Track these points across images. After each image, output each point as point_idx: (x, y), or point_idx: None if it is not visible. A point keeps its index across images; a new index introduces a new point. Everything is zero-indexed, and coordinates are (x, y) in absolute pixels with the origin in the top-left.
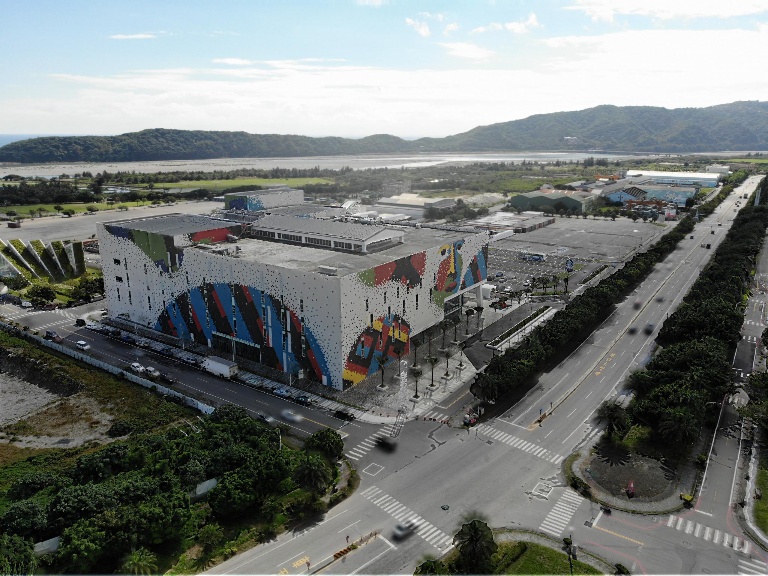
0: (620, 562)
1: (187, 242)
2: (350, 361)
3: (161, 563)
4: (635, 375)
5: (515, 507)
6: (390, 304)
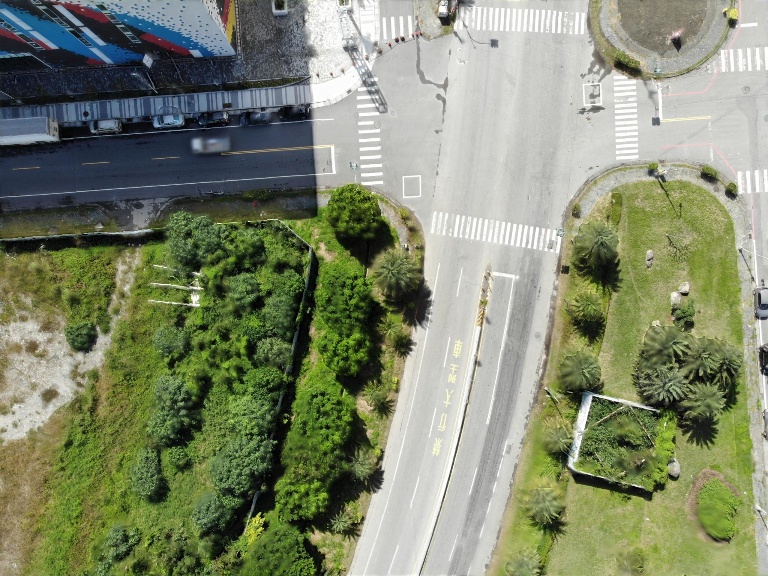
0: (700, 157)
1: None
2: (221, 12)
3: (354, 434)
4: None
5: (582, 145)
6: None
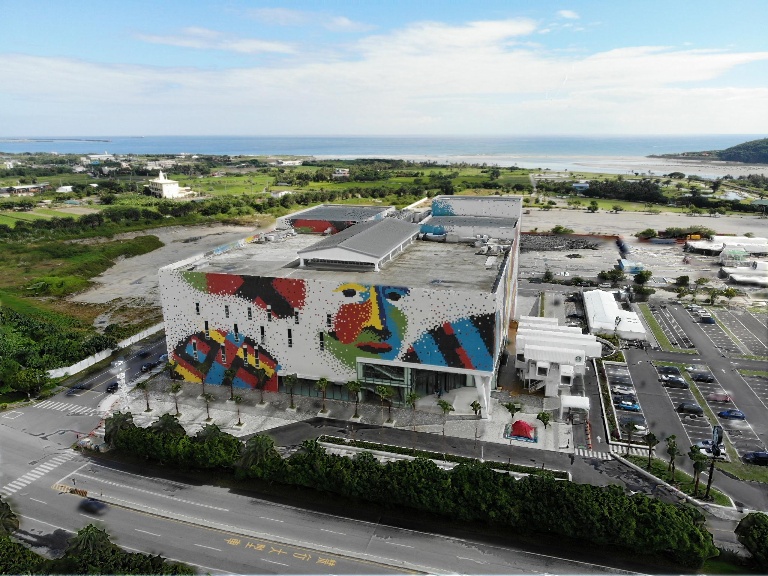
0: None
1: (289, 226)
2: (179, 355)
3: None
4: (87, 527)
5: None
6: (238, 321)
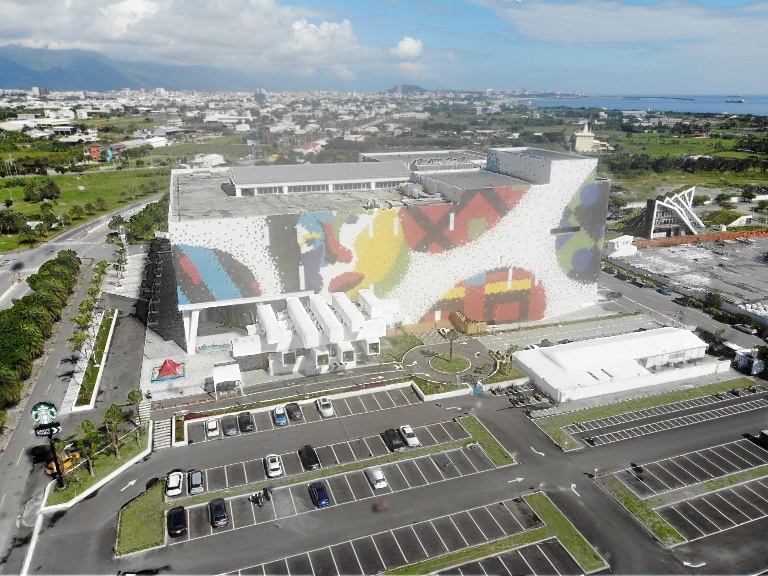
0: None
1: None
2: None
3: None
4: None
5: None
6: None
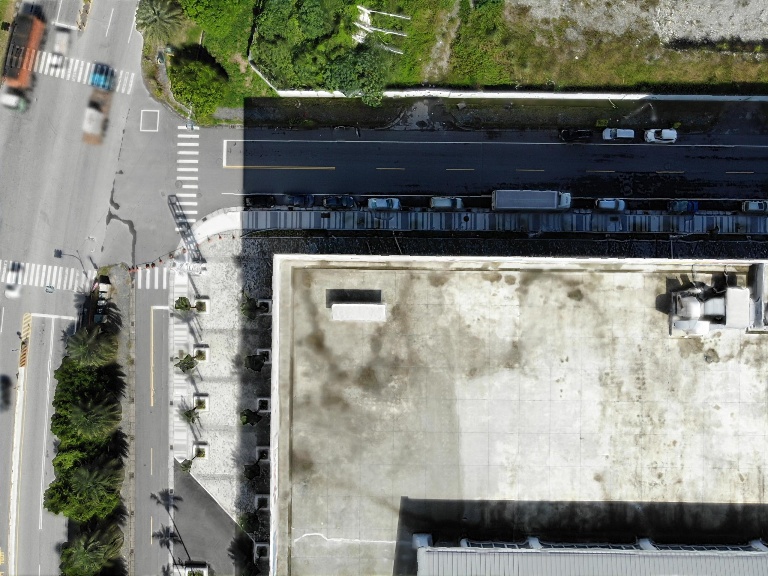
0: None
1: None
2: None
3: None
4: None
5: None
6: None
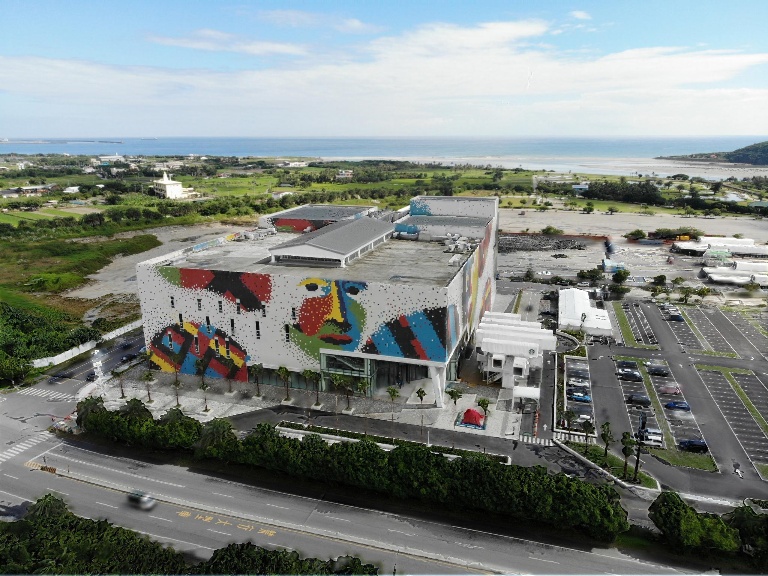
0: None
1: (271, 225)
2: (156, 346)
3: None
4: (46, 496)
5: None
6: (210, 314)
